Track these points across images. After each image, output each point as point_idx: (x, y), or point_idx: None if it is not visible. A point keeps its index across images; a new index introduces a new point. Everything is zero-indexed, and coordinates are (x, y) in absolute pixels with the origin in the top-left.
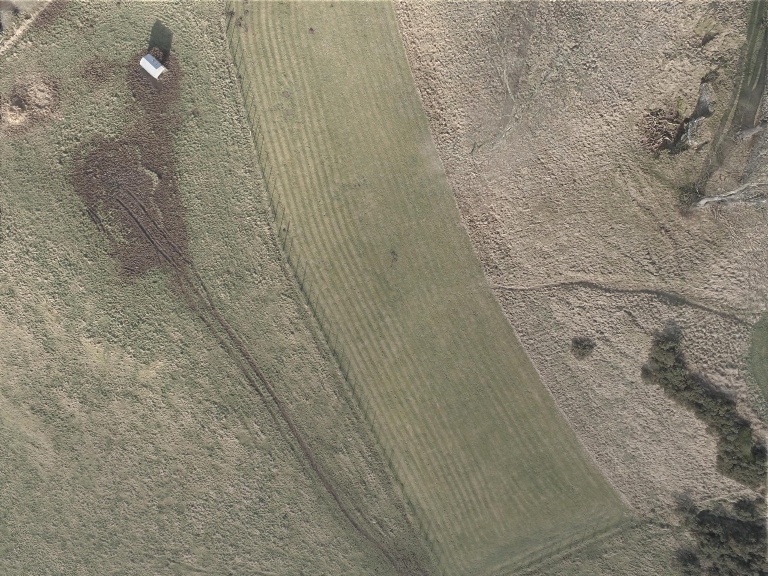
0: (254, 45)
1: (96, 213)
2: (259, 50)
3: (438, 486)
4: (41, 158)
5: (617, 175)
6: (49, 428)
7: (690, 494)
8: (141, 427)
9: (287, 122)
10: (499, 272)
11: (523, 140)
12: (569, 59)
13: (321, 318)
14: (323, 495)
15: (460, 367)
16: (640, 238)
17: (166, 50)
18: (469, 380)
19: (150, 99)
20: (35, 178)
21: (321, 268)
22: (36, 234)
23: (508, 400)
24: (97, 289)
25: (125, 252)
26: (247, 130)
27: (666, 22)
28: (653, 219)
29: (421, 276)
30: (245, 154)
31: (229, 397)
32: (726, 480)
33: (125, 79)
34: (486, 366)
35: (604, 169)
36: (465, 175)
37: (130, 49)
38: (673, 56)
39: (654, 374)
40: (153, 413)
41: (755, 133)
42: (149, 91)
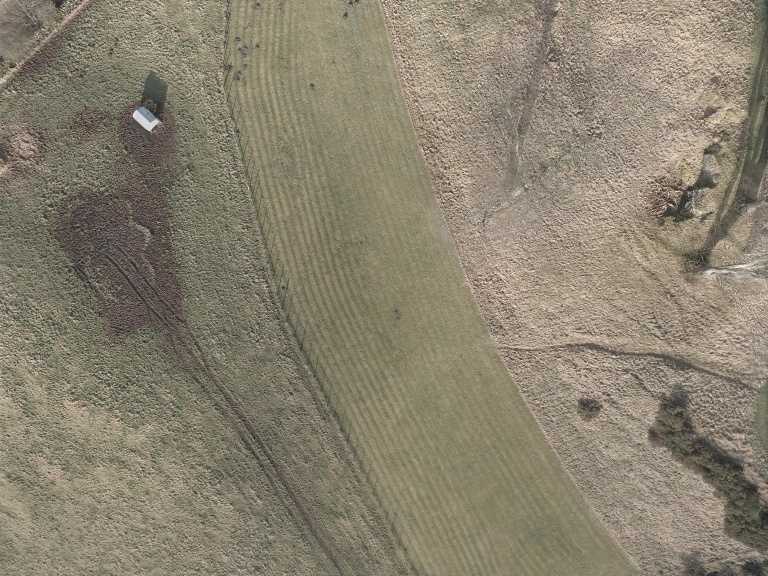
0: (253, 99)
1: (83, 270)
2: (258, 104)
3: (442, 550)
4: (24, 212)
5: (622, 240)
6: (27, 497)
7: (698, 556)
8: (128, 494)
9: (287, 178)
10: (504, 332)
11: (528, 202)
12: (574, 125)
13: (321, 378)
14: (322, 562)
15: (465, 428)
16: (646, 302)
17: (160, 102)
18: (474, 441)
19: (143, 152)
20: (17, 233)
21: (322, 327)
22: (17, 292)
23: (514, 461)
24: (83, 350)
25: (114, 310)
26: (245, 185)
27: (669, 93)
28: (658, 284)
29: (425, 335)
30: (243, 210)
31: (224, 461)
32: (733, 542)
33: (116, 131)
34: (491, 427)
35: (609, 233)
36: (469, 234)
37: (122, 100)
38: (676, 126)
39: (661, 437)
40: (141, 479)
41: (759, 206)
42: (142, 144)
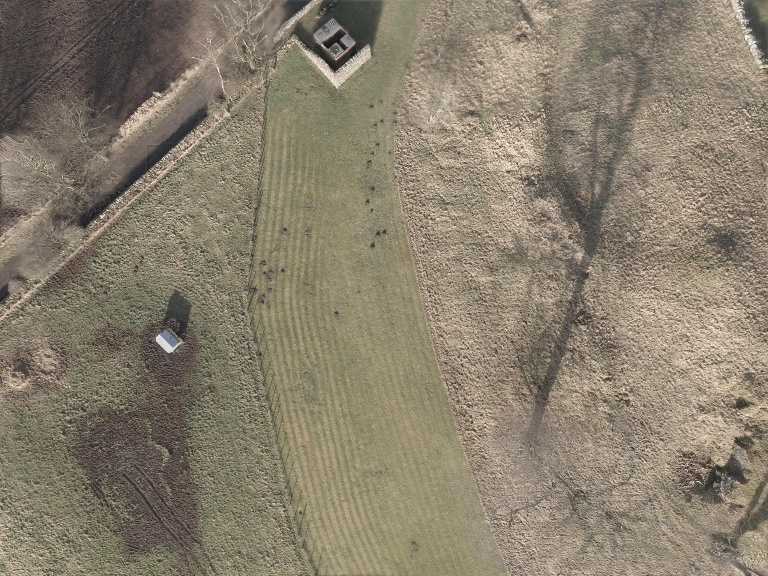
0: (276, 323)
1: (100, 488)
2: (281, 329)
3: None
4: (43, 427)
5: (648, 508)
6: None
7: None
8: None
9: (308, 403)
10: (523, 573)
11: (552, 453)
12: (601, 389)
13: None
14: None
15: None
16: (669, 570)
17: (183, 322)
18: None
19: (164, 371)
20: (35, 449)
21: (338, 554)
22: (33, 508)
23: None
24: (97, 567)
25: (129, 529)
26: (265, 409)
27: (700, 376)
28: (683, 555)
29: (442, 568)
30: (262, 433)
31: None
32: None
33: (138, 349)
34: None
35: (634, 499)
36: (490, 474)
37: (145, 319)
38: (707, 410)
39: None
40: None
41: None
42: (163, 363)
